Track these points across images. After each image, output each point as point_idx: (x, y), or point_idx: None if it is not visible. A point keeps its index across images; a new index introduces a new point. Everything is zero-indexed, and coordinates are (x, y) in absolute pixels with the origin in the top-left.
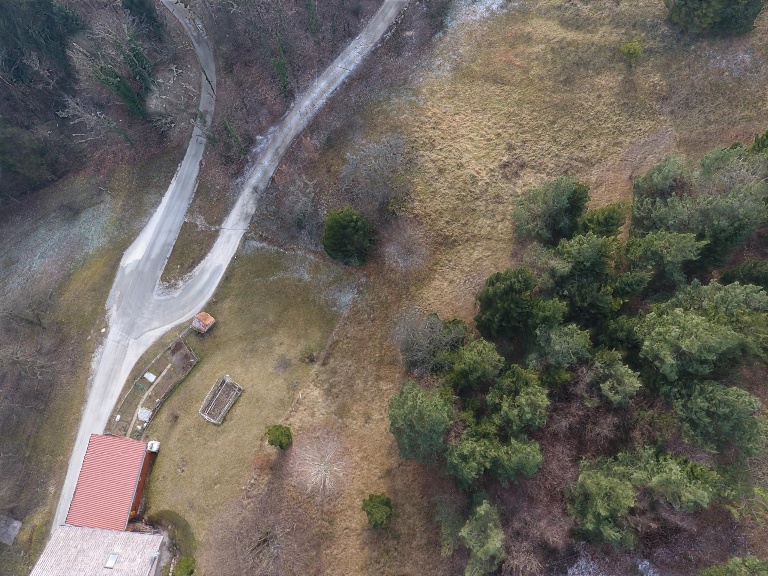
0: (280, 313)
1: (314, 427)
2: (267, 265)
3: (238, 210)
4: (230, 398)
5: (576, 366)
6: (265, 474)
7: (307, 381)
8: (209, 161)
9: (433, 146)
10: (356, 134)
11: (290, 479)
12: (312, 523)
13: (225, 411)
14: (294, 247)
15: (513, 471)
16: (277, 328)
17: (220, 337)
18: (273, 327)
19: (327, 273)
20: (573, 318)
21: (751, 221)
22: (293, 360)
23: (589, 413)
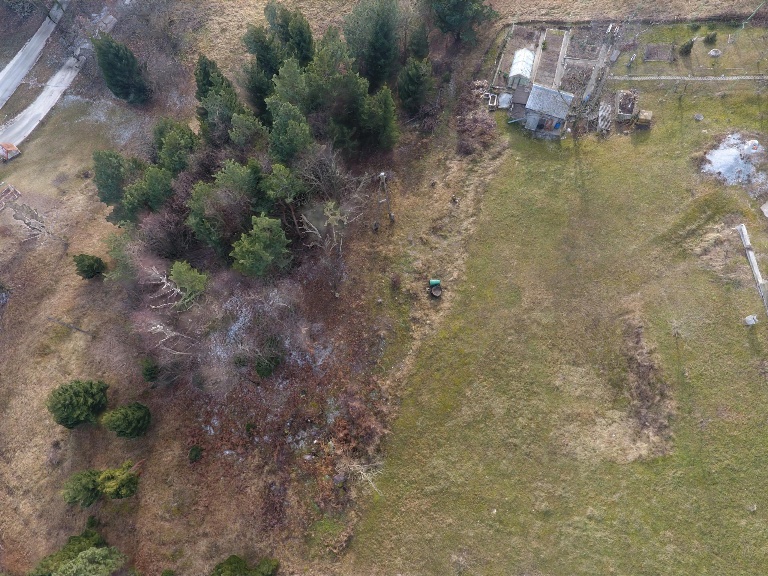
0: (72, 144)
1: (67, 218)
2: (76, 112)
3: (64, 71)
4: (8, 200)
5: (219, 122)
6: (14, 248)
7: (76, 190)
8: (54, 37)
9: (222, 12)
10: (164, 5)
11: (33, 252)
12: (41, 282)
13: (1, 209)
14: (100, 97)
15: (152, 197)
16: (66, 154)
17: (19, 162)
18: (63, 154)
19: (121, 115)
20: (253, 107)
21: (381, 17)
22: (70, 176)
23: None
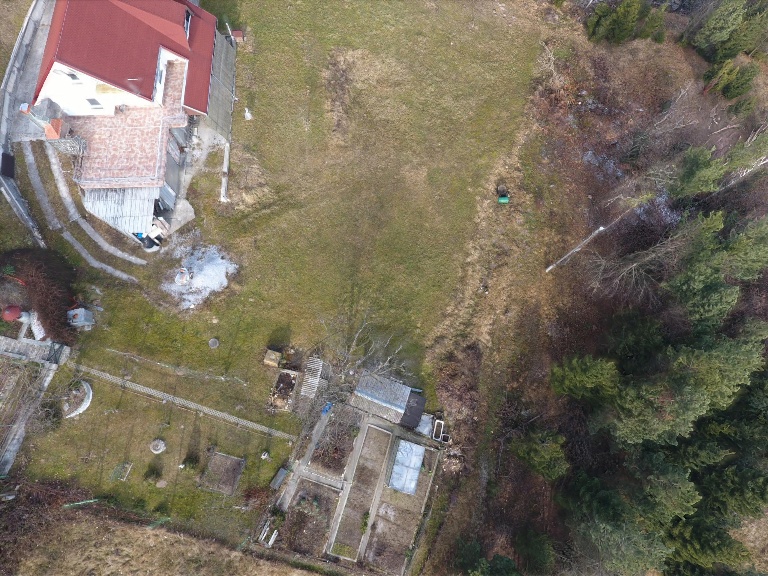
0: None
1: None
2: None
3: None
4: None
5: None
6: None
7: None
8: None
9: None
10: None
11: None
12: None
13: None
14: None
15: None
16: None
17: None
18: None
19: None
20: None
21: None
22: None
23: (761, 316)
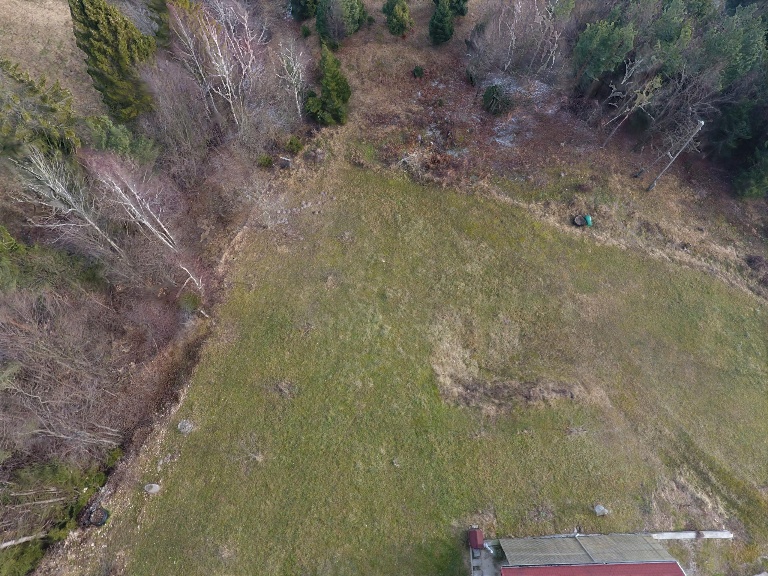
0: None
1: None
2: None
3: None
4: None
5: None
6: None
7: None
8: None
9: None
10: None
11: None
12: None
13: None
14: None
15: None
16: None
17: None
18: None
19: None
20: None
21: None
22: None
23: None
